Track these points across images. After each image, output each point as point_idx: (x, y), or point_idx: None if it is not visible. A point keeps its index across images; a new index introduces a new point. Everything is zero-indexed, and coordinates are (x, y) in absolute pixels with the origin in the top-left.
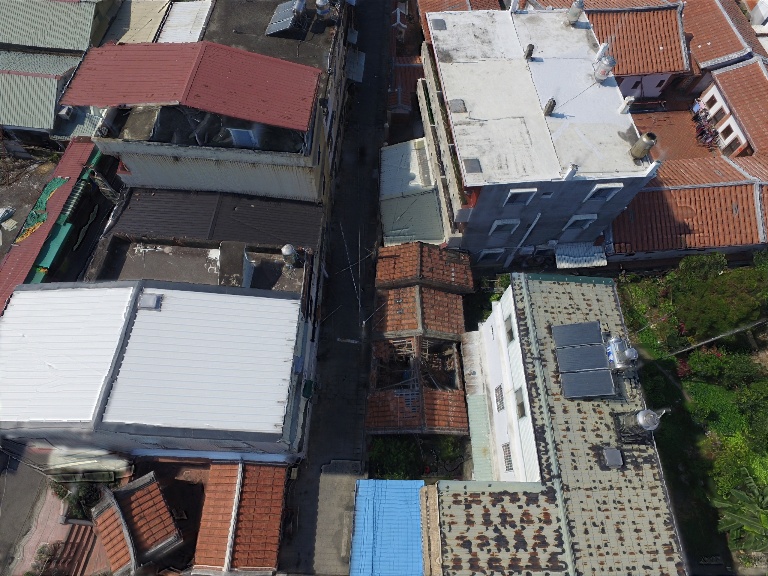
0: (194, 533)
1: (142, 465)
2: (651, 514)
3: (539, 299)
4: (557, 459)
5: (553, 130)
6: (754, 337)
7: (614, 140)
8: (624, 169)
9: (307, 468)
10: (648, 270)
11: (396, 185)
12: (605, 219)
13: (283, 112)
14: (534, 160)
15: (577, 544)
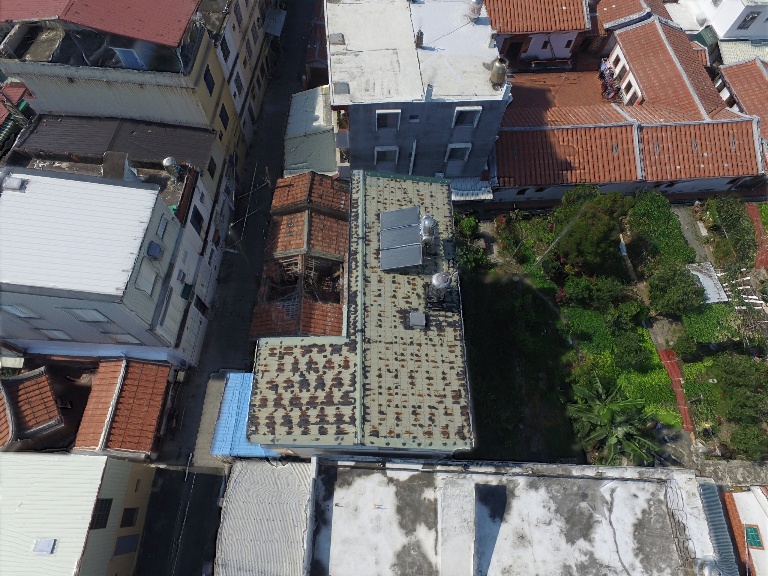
0: (77, 421)
1: (34, 361)
2: (445, 366)
3: (374, 192)
4: (363, 317)
5: (422, 60)
6: (634, 269)
7: (478, 69)
8: (482, 93)
9: (197, 375)
10: (540, 209)
11: (301, 126)
12: (482, 150)
13: (158, 30)
14: (400, 84)
15: (369, 385)
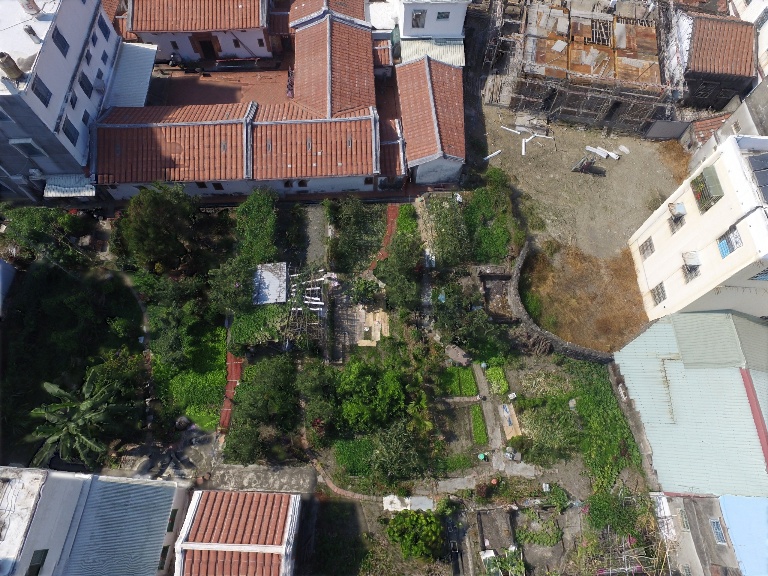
0: None
1: None
2: None
3: None
4: None
5: None
6: None
7: None
8: None
9: None
10: None
11: None
12: (54, 146)
13: None
14: None
15: None
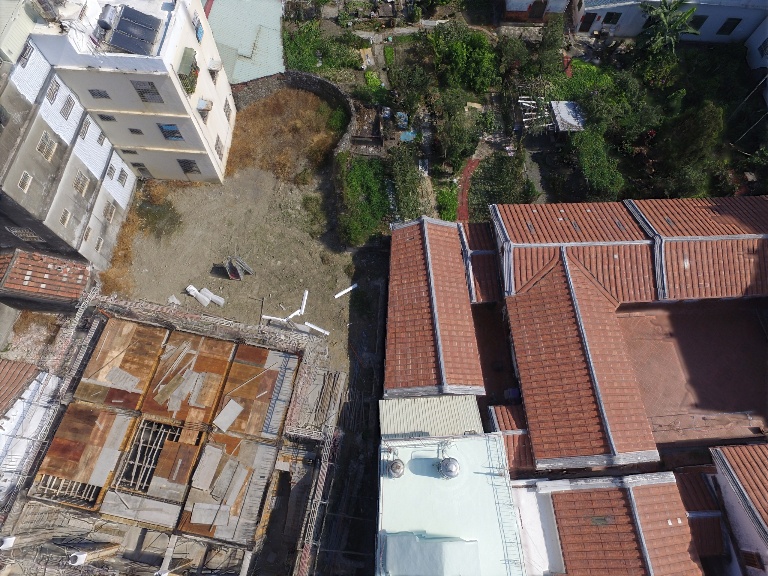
0: None
1: None
2: None
3: None
4: None
5: None
6: None
7: None
8: None
9: None
10: None
11: None
12: None
13: None
14: None
15: None
